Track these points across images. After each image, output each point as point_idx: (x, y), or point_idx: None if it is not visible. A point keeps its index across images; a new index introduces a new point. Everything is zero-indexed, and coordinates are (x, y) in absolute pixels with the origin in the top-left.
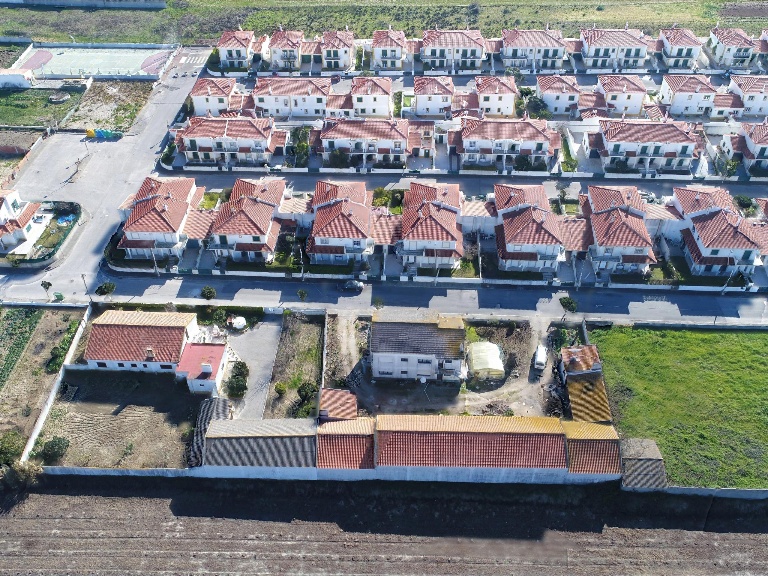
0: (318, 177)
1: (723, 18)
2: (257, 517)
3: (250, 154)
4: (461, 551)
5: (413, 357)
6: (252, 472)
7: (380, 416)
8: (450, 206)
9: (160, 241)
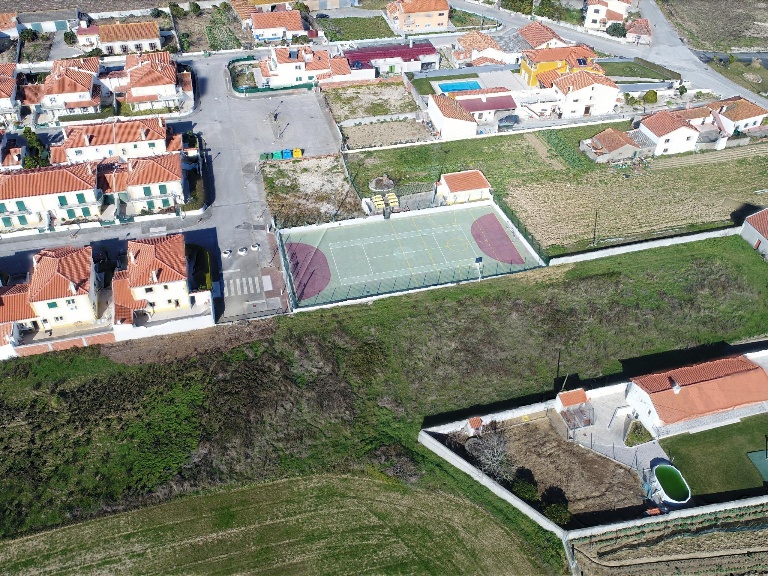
0: None
1: None
2: None
3: None
4: None
5: None
6: None
7: None
8: None
9: None
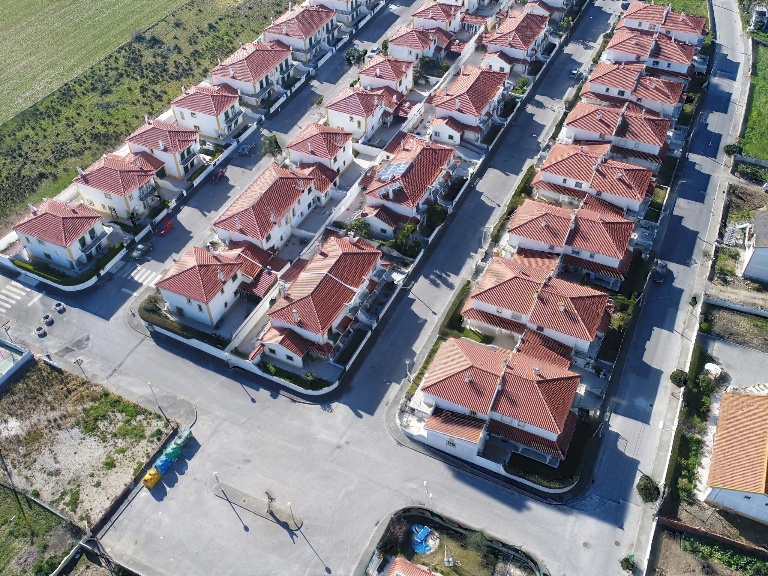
0: (439, 248)
1: None
2: None
3: None
4: None
5: None
6: None
7: None
8: None
9: None
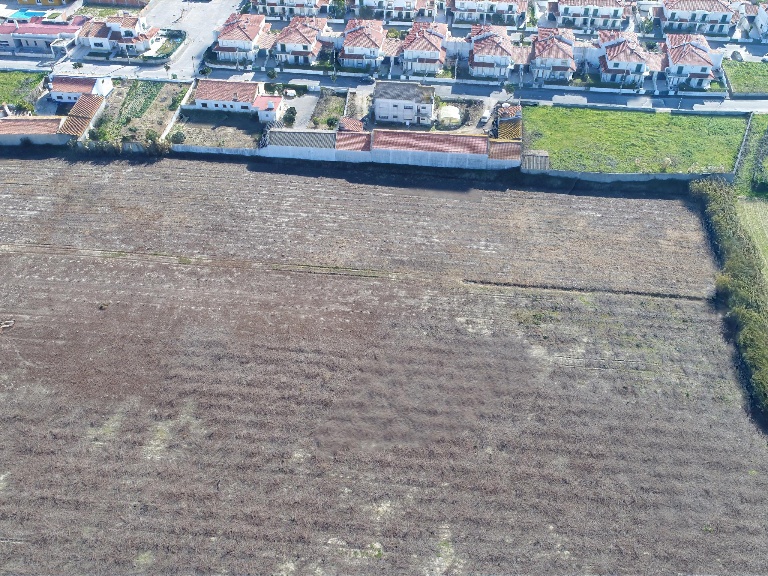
0: None
1: None
2: (298, 174)
3: (303, 9)
4: (418, 194)
5: (401, 104)
6: (296, 153)
7: (377, 129)
8: (438, 33)
9: (241, 48)
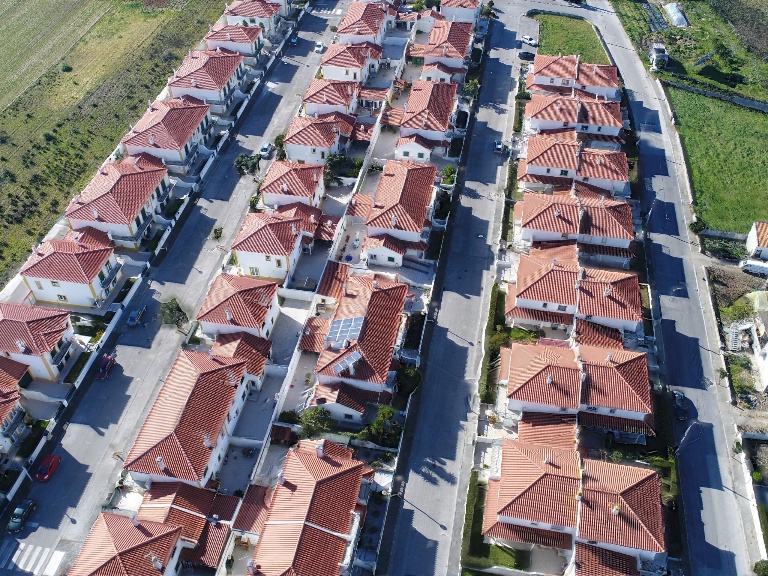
0: (420, 423)
1: (167, 8)
2: None
3: None
4: None
5: None
6: None
7: None
8: None
9: None
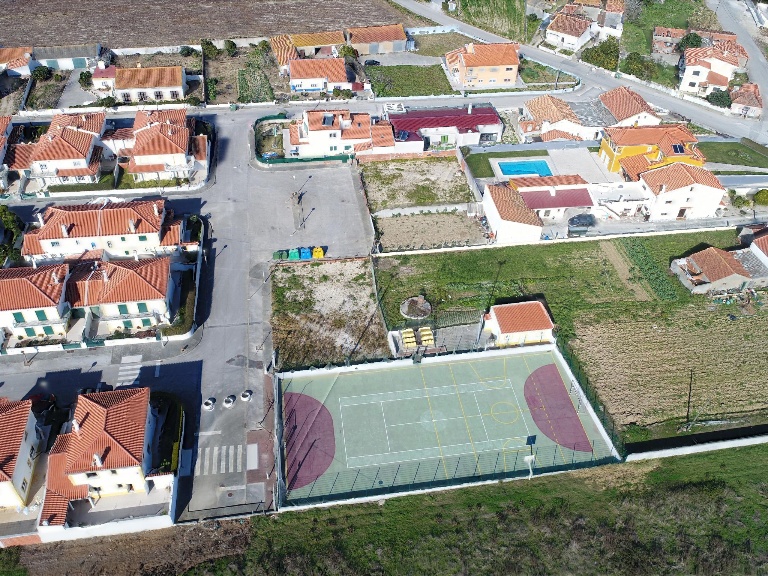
0: (0, 223)
1: None
2: None
3: None
4: None
5: None
6: None
7: None
8: None
9: None
